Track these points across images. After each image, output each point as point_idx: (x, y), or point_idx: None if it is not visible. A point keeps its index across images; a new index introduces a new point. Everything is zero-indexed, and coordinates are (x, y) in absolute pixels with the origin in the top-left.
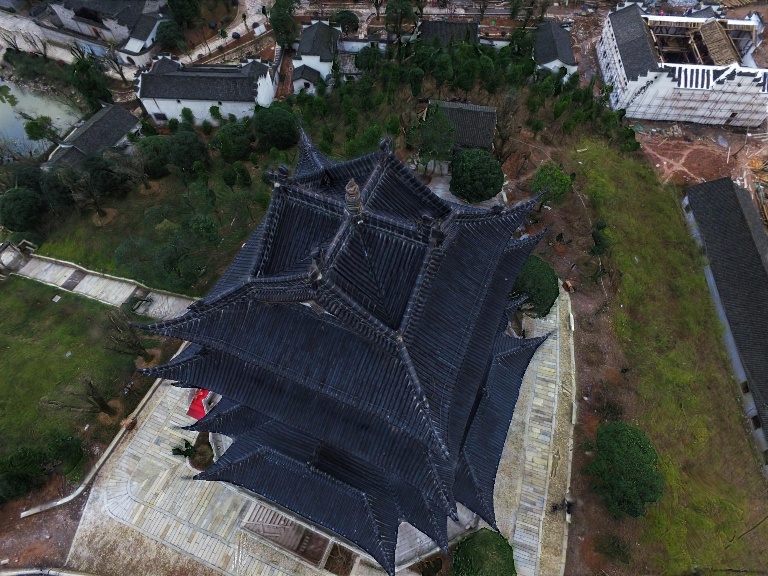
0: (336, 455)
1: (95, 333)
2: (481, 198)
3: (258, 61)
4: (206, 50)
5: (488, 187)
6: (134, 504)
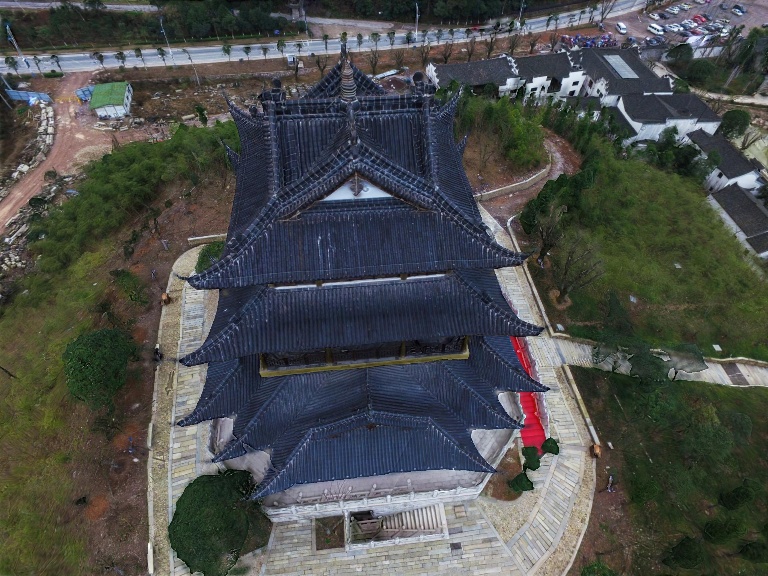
0: None
1: (636, 321)
2: None
3: None
4: None
5: None
6: None
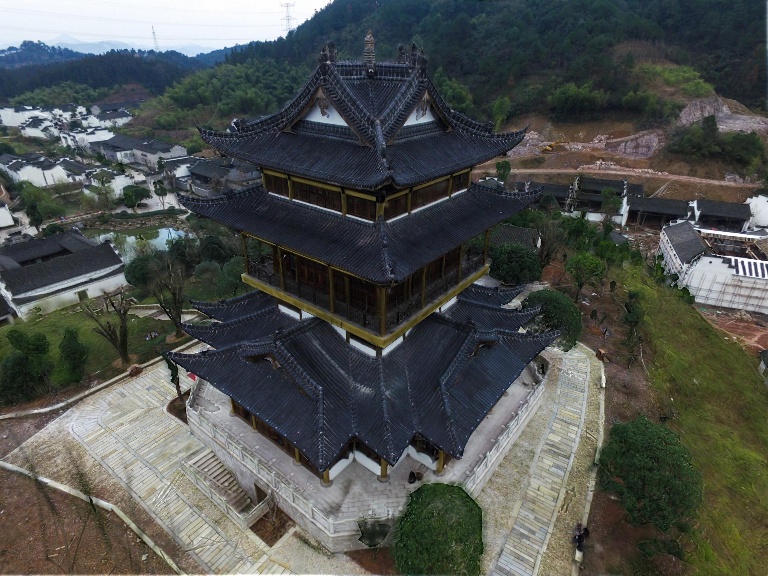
0: (307, 352)
1: None
2: (517, 280)
3: None
4: None
5: (524, 269)
6: (97, 427)
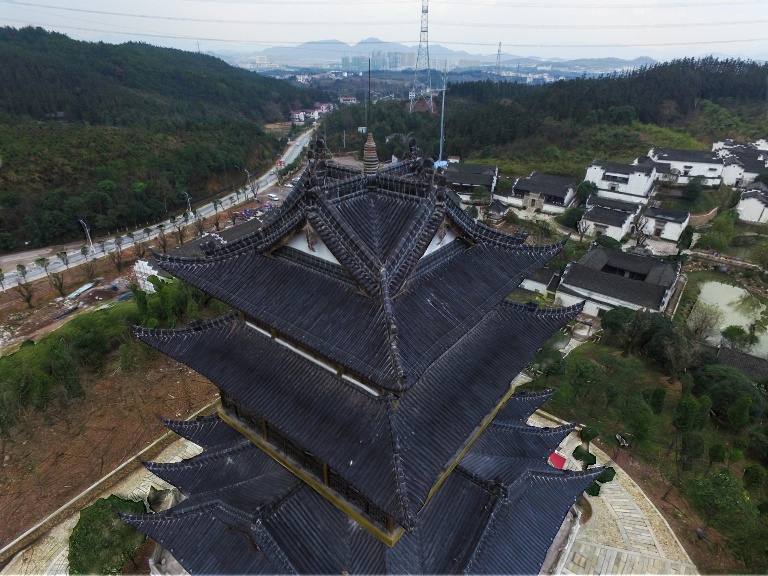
0: None
1: None
2: None
3: None
4: None
5: None
6: None
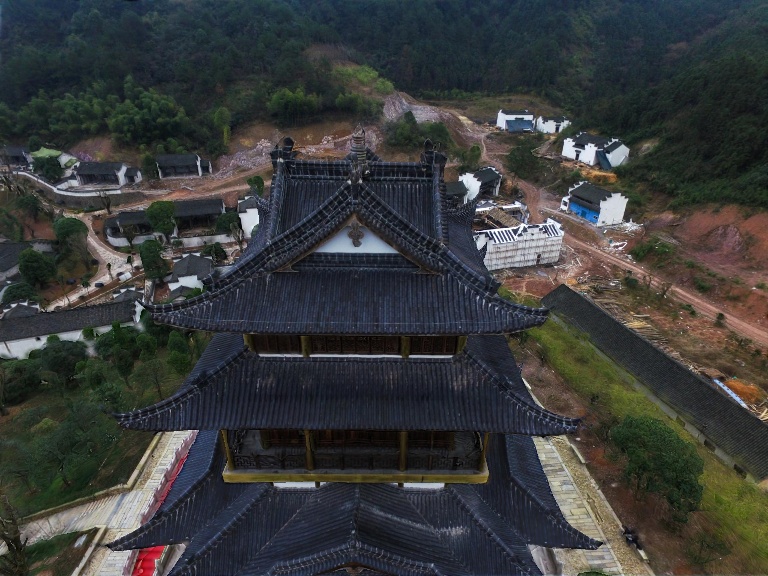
0: (378, 529)
1: None
2: None
3: (132, 290)
4: (65, 301)
5: None
6: None
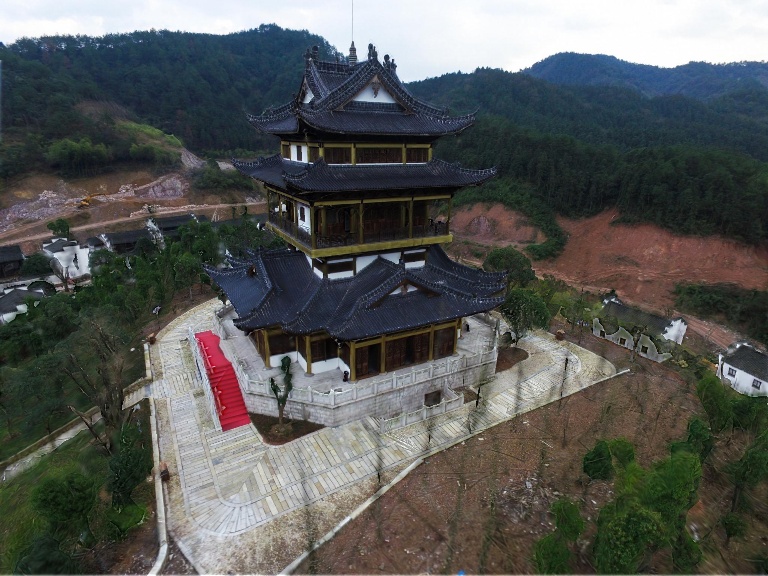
0: None
1: None
2: None
3: None
4: None
5: None
6: (255, 505)
